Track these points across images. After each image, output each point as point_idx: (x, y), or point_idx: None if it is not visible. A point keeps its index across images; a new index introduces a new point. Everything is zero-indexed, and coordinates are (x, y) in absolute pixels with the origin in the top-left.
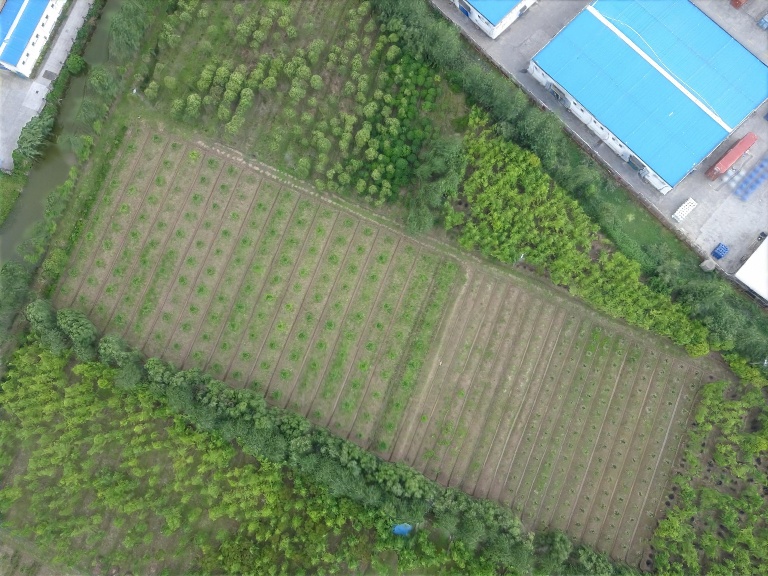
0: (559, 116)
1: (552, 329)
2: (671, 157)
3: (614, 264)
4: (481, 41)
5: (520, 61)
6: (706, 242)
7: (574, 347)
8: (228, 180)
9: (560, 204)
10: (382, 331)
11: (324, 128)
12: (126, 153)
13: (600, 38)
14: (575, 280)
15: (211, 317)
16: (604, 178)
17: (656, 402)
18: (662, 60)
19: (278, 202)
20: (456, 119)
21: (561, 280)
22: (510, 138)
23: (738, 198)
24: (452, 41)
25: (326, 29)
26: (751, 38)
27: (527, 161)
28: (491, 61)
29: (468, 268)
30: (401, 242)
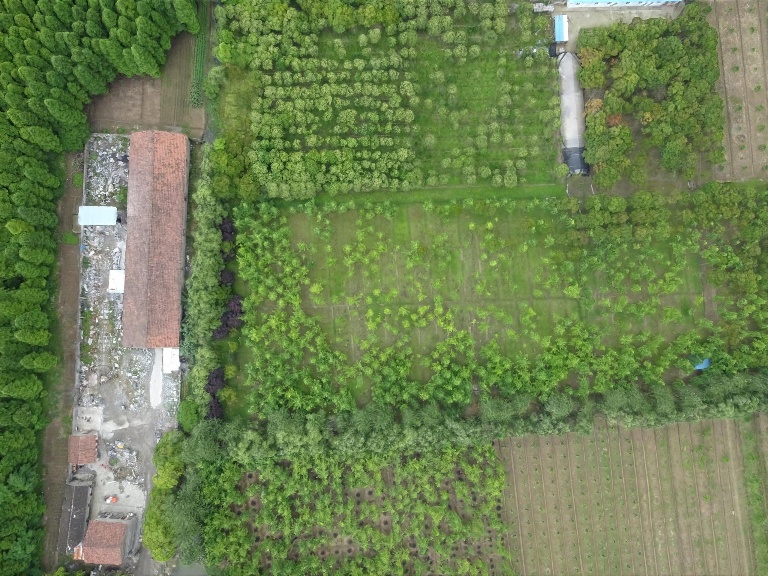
0: None
1: None
2: None
3: None
4: None
5: None
6: None
7: None
8: None
9: None
10: None
11: None
12: None
13: None
14: None
15: None
16: None
17: None
18: None
19: None
20: None
21: None
22: None
23: None
24: None
25: None
26: None
27: None
28: None
29: None
30: None
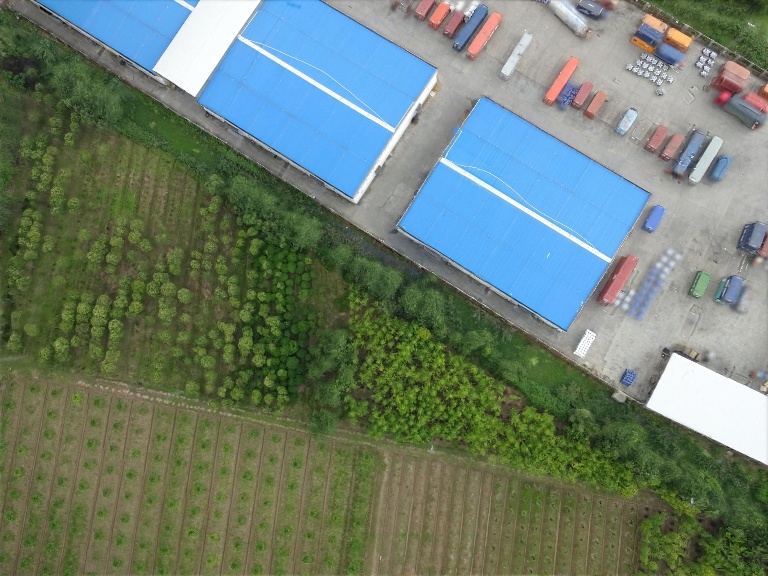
0: (440, 272)
1: (482, 496)
2: (558, 300)
3: (526, 424)
4: (344, 208)
5: (388, 221)
6: (613, 371)
7: (508, 510)
8: (119, 416)
9: (460, 373)
10: (314, 539)
11: (204, 343)
12: (5, 411)
13: (461, 190)
14: (492, 447)
15: (137, 568)
16: (499, 329)
17: (599, 547)
18: (527, 200)
19: (177, 427)
20: (337, 299)
21: (478, 452)
22: (395, 315)
23: (634, 318)
24: (312, 229)
25: (182, 230)
26: (612, 147)
27: (417, 337)
28: (359, 229)
29: (385, 452)
30: (312, 441)
